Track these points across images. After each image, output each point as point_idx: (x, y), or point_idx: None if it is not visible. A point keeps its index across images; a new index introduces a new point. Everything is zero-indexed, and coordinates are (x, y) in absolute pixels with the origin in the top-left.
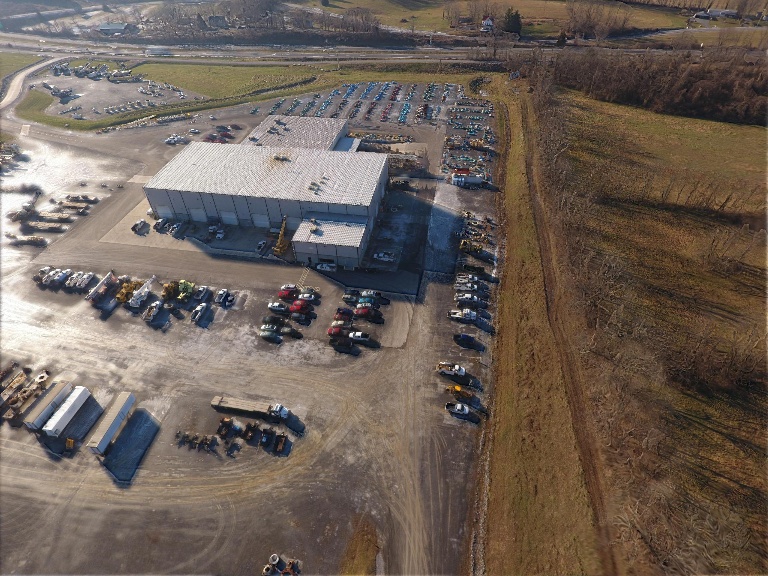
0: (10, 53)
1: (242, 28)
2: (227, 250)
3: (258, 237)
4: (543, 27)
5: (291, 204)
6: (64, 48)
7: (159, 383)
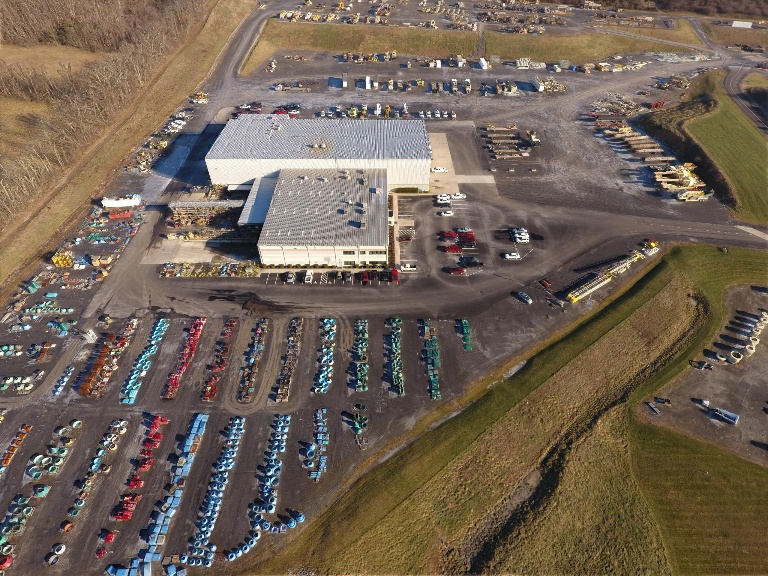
0: None
1: None
2: None
3: None
4: None
5: None
6: None
7: (339, 93)
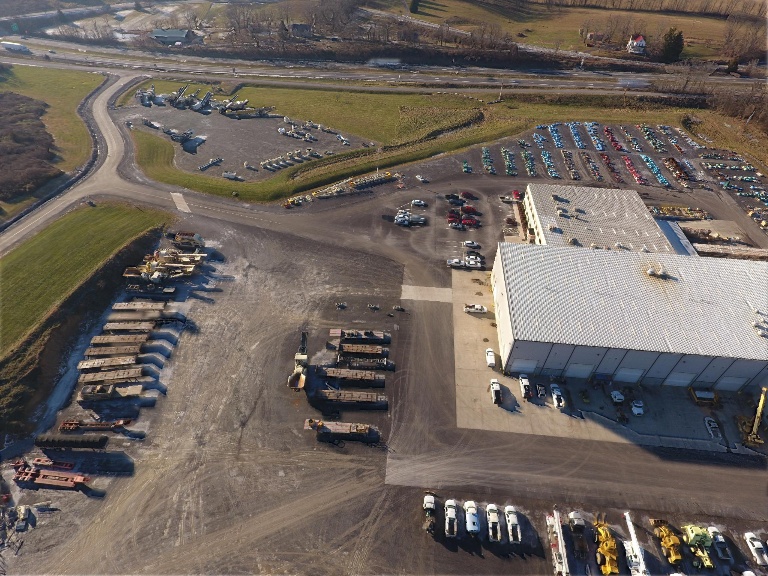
0: (55, 68)
1: (337, 40)
2: (667, 438)
3: (686, 407)
4: (696, 49)
5: (752, 364)
6: (120, 62)
7: None
